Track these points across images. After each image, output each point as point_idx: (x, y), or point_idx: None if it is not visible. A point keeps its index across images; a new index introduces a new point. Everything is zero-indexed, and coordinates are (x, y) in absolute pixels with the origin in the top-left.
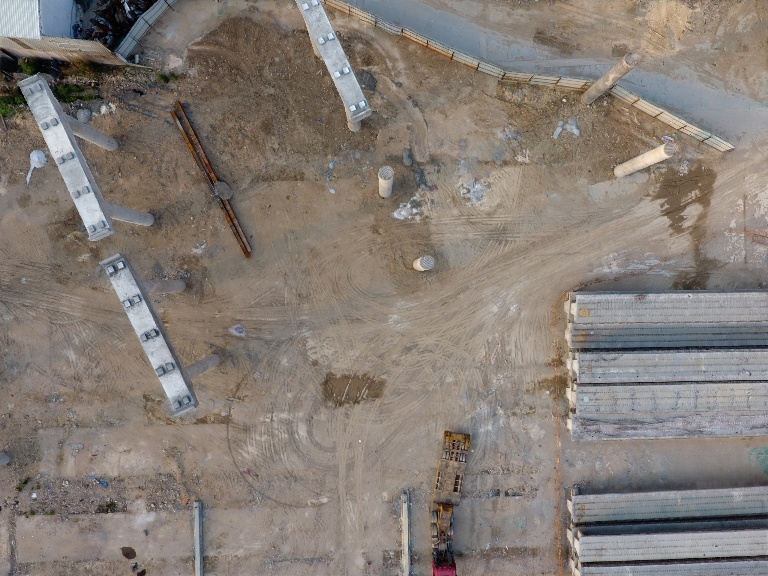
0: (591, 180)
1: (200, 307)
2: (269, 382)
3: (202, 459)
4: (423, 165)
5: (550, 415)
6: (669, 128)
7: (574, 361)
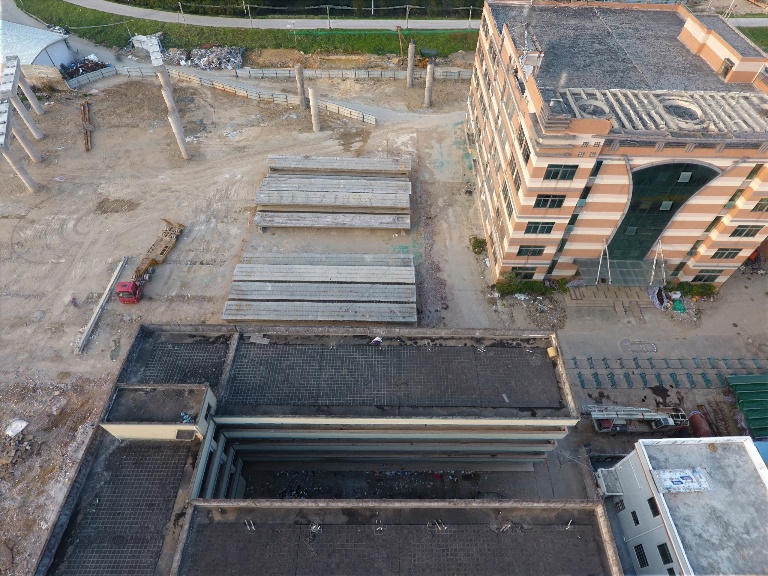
0: (300, 132)
1: (44, 169)
2: (64, 201)
3: None
4: (207, 125)
5: (247, 223)
6: (346, 117)
7: None
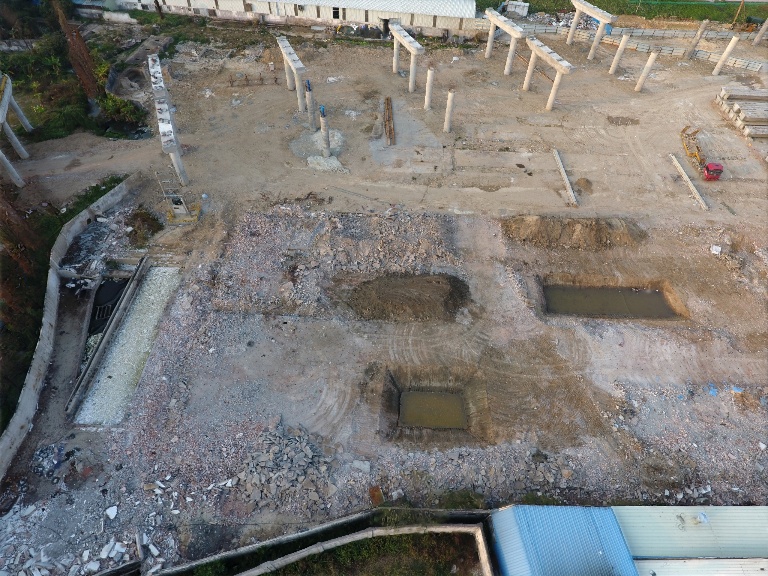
0: None
1: (537, 95)
2: None
3: (552, 137)
4: None
5: None
6: (728, 66)
7: (734, 107)
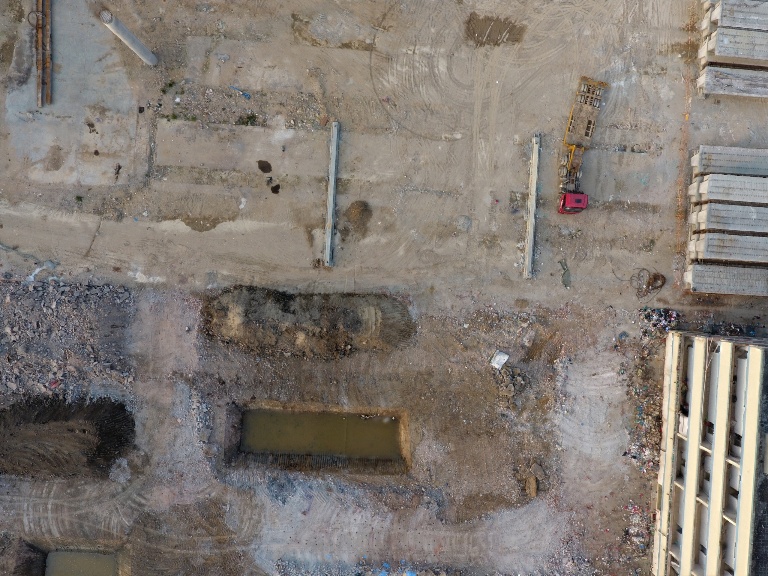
0: None
1: None
2: (415, 15)
3: (344, 83)
4: None
5: (680, 77)
6: None
7: (715, 10)
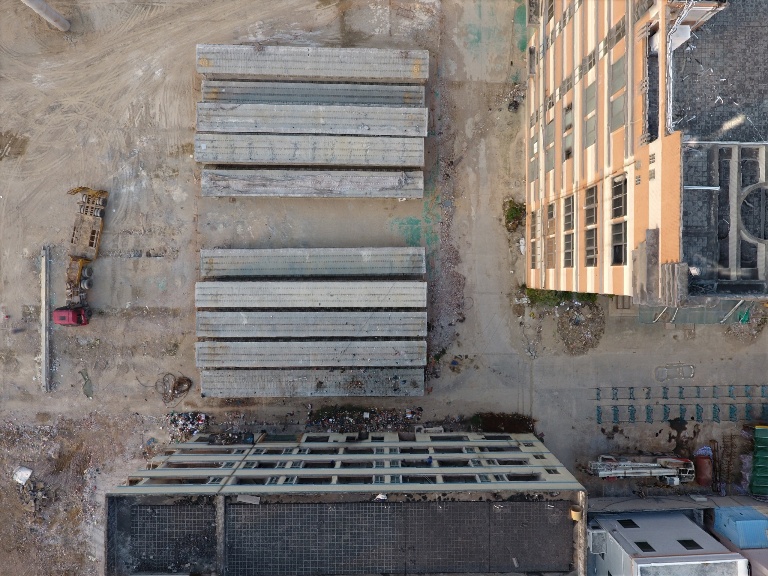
0: None
1: None
2: None
3: None
4: None
5: (192, 178)
6: None
7: None
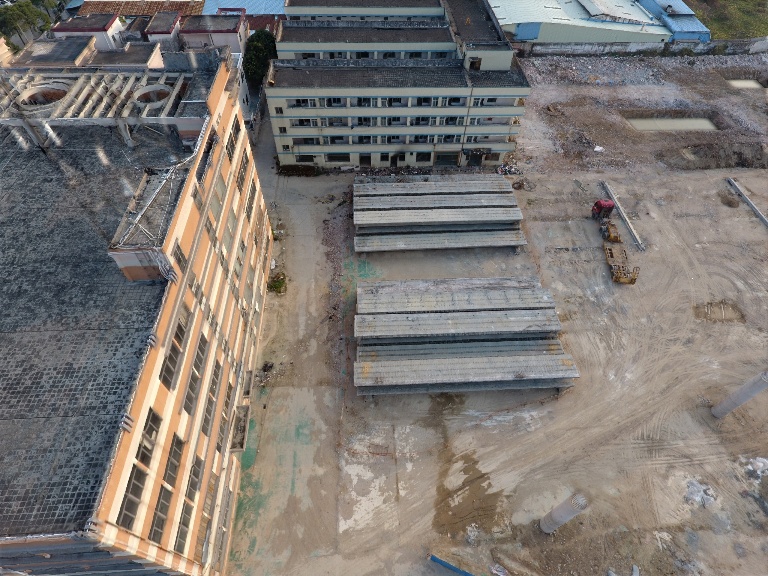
0: None
1: None
2: None
3: None
4: None
5: None
6: None
7: None
